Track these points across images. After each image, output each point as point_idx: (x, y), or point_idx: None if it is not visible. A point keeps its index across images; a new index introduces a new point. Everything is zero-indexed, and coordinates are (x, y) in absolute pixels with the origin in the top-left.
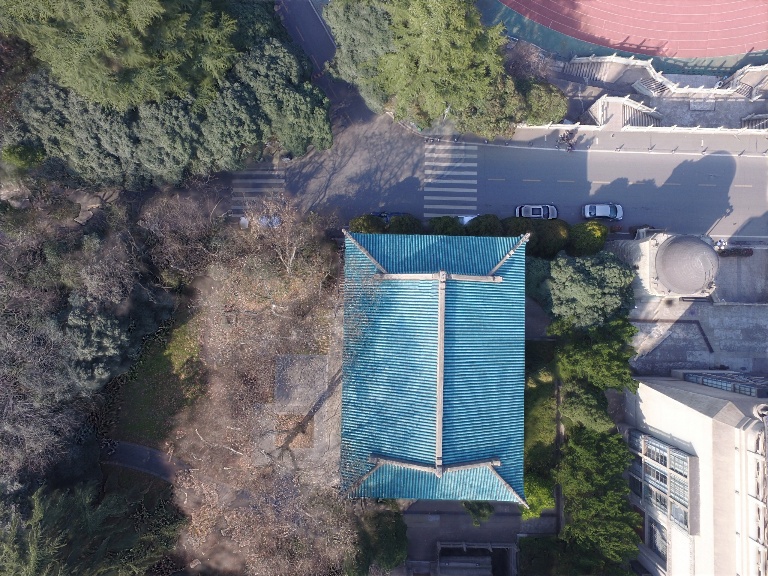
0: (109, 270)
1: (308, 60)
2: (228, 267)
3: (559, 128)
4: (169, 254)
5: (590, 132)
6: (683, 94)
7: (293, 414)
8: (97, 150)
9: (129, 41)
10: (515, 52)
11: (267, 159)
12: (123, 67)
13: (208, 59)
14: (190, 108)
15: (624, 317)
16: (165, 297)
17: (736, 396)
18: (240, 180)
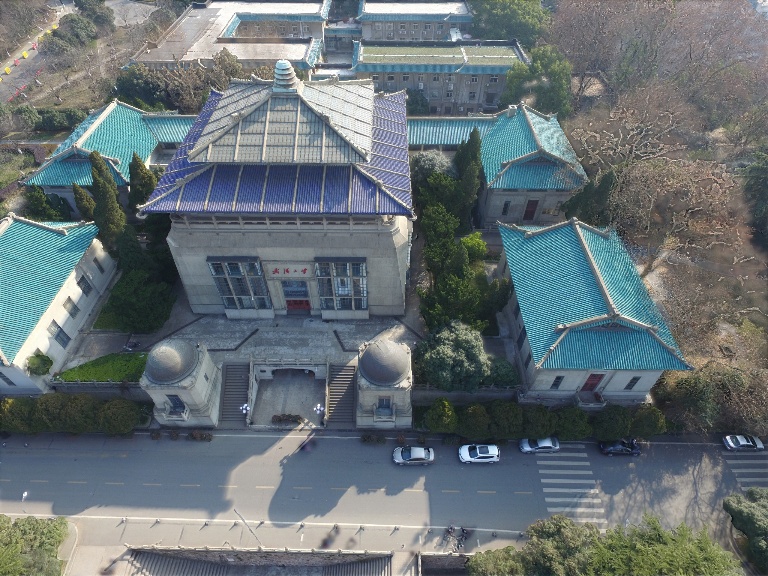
0: None
1: None
2: None
3: None
4: None
5: (429, 551)
6: None
7: None
8: None
9: None
10: None
11: None
12: None
13: None
14: None
15: (438, 323)
16: None
17: (378, 261)
18: None
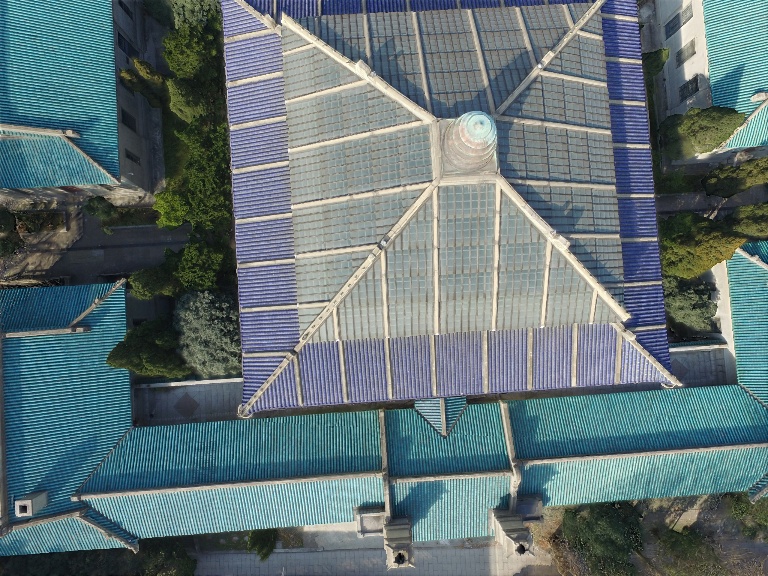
0: None
1: None
2: None
3: None
4: None
5: None
6: None
7: None
8: None
9: None
10: None
11: None
12: None
13: None
14: None
15: None
16: None
17: None
18: None
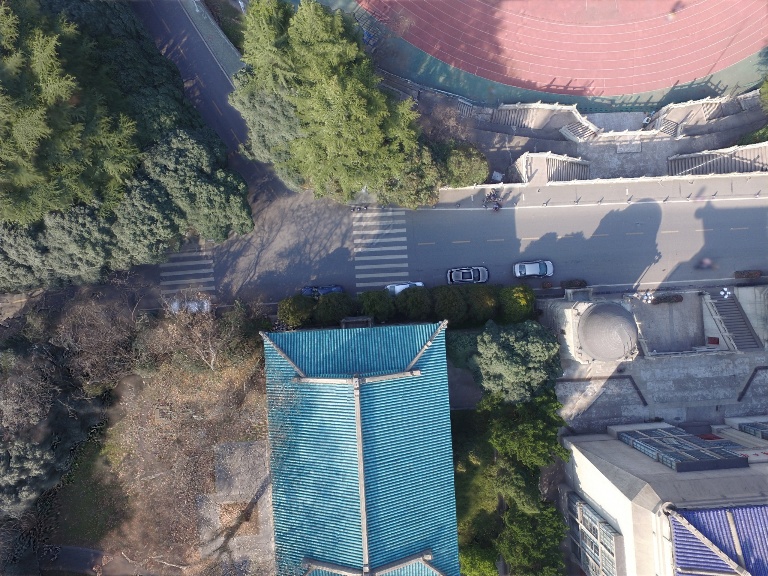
0: (24, 391)
1: (221, 145)
2: (157, 361)
3: (485, 187)
4: (86, 367)
5: (516, 189)
6: (609, 137)
7: (236, 503)
8: (5, 263)
9: (19, 162)
10: (433, 117)
11: (193, 241)
12: (17, 186)
13: (110, 164)
14: (97, 213)
15: (549, 391)
16: (90, 405)
17: (657, 471)
18: (167, 264)
